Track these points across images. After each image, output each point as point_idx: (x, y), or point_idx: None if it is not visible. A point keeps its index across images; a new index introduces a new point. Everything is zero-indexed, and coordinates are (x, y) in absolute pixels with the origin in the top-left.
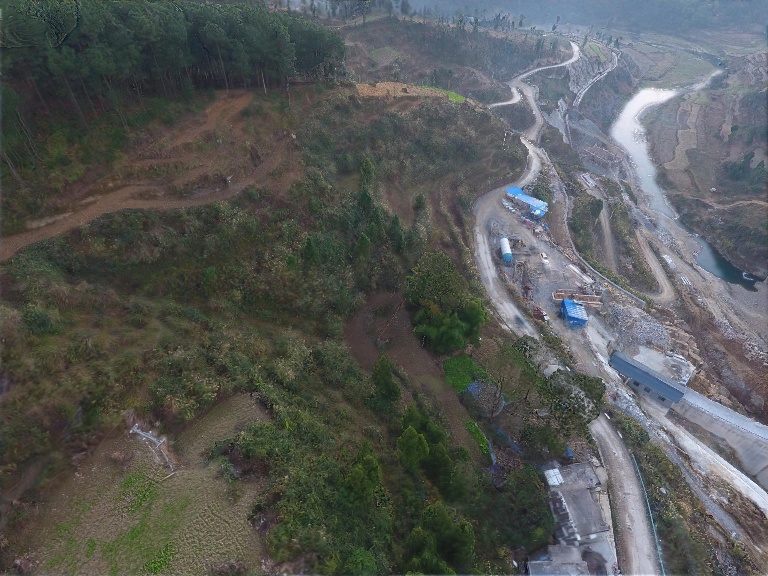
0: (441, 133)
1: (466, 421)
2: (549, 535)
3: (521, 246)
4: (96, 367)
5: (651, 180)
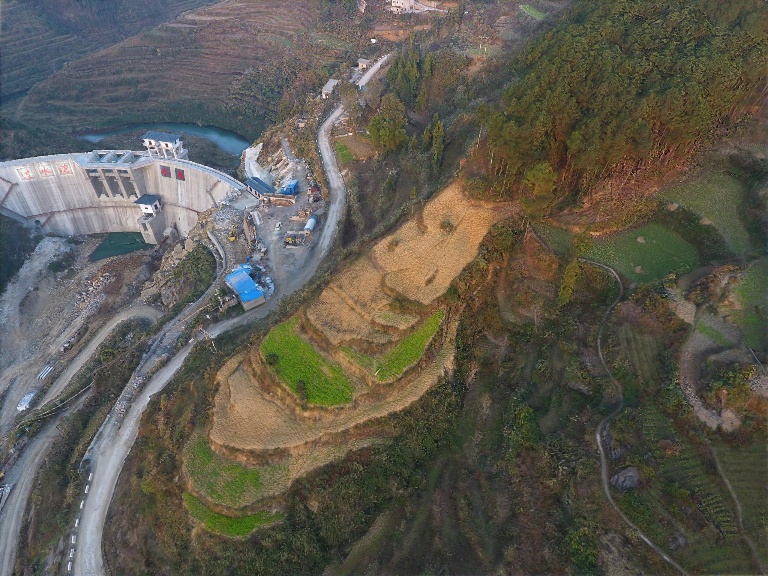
0: None
1: None
2: None
3: None
4: None
5: None
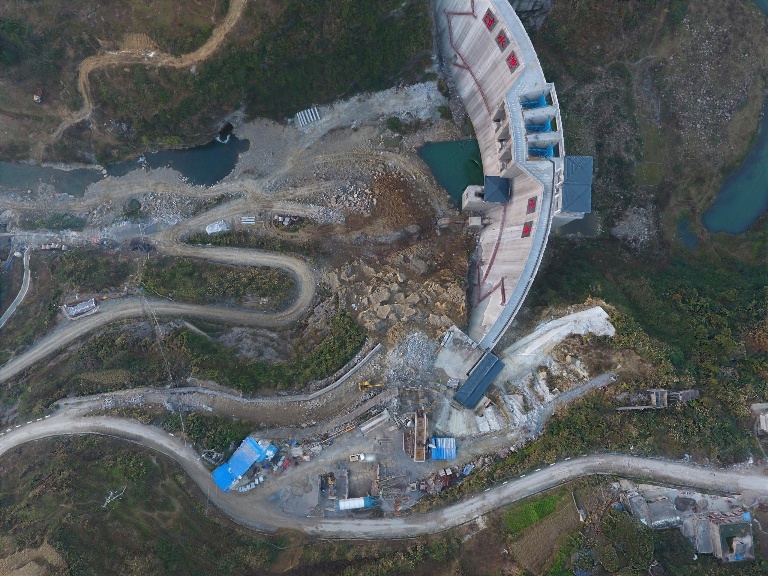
0: None
1: None
2: (683, 538)
3: (335, 479)
4: None
5: None
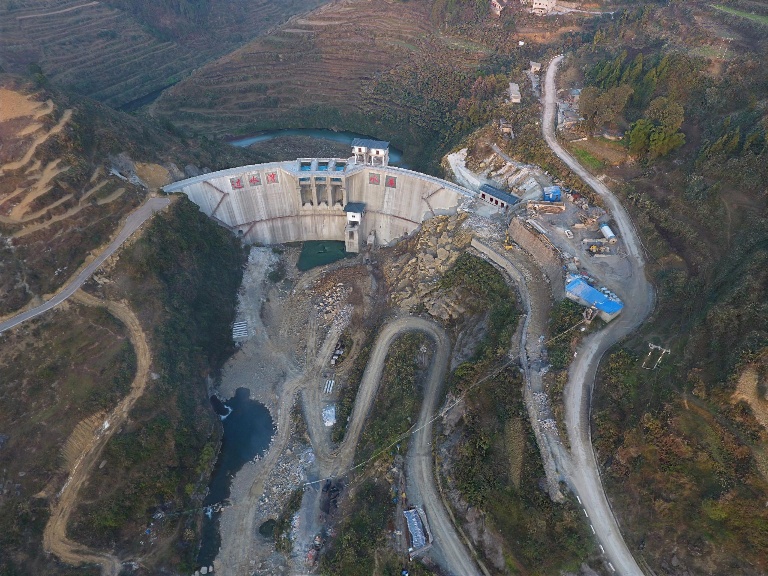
0: (765, 271)
1: (622, 124)
2: None
3: None
4: (767, 52)
5: None
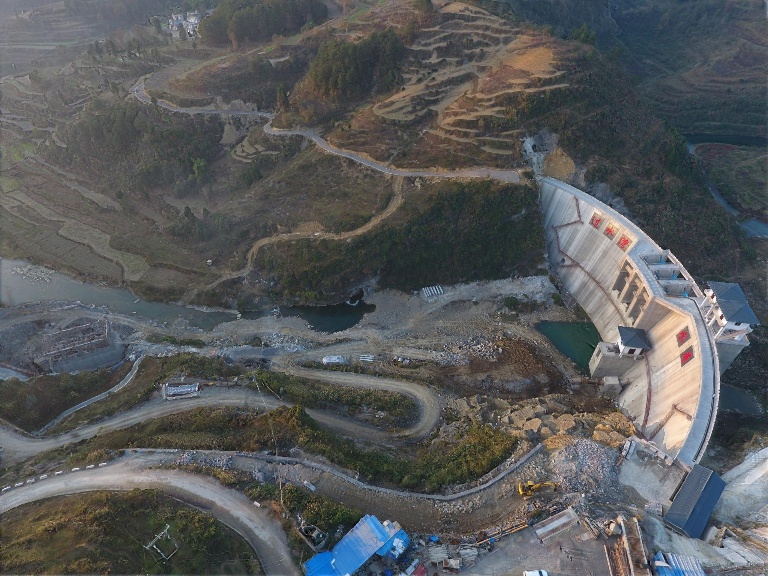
0: None
1: None
2: None
3: None
4: None
5: (146, 304)
